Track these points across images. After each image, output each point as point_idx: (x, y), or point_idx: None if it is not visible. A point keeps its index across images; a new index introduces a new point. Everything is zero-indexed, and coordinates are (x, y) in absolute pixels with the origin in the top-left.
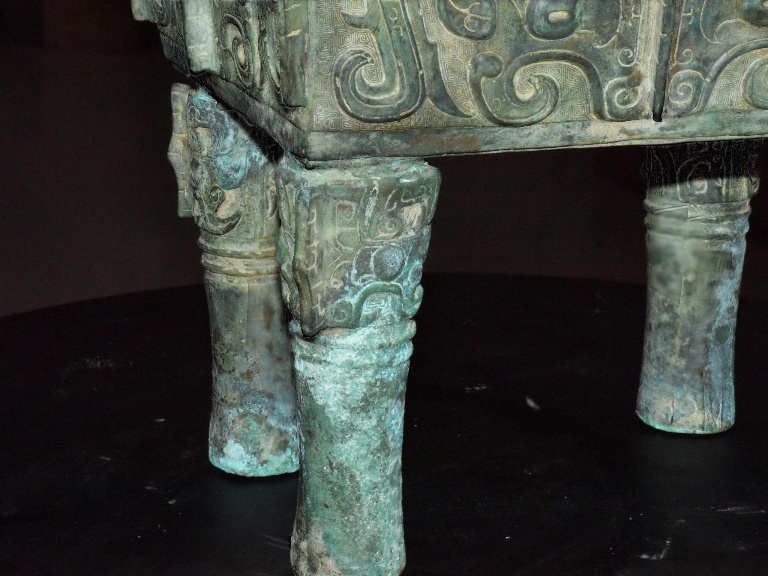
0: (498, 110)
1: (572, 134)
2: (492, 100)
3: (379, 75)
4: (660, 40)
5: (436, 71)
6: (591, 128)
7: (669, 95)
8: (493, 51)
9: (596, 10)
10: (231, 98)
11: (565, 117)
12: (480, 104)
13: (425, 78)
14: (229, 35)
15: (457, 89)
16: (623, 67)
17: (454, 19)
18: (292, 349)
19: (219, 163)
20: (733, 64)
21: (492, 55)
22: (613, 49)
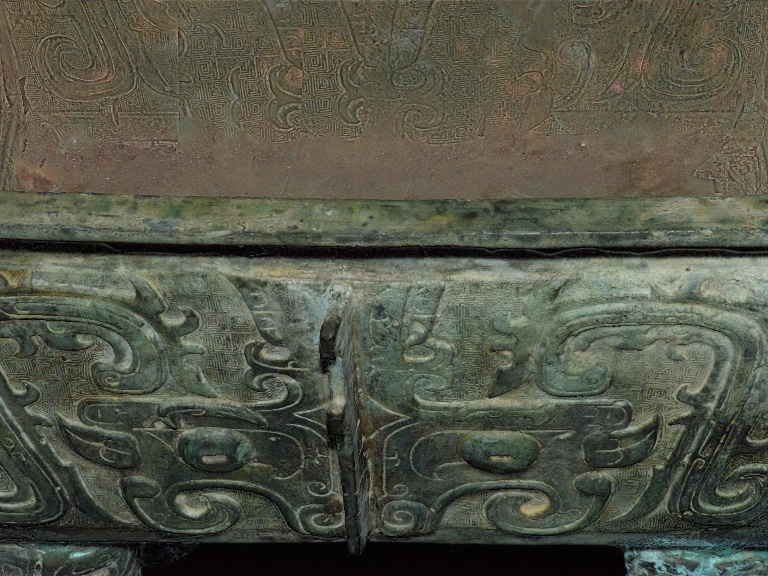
0: (163, 522)
1: (272, 535)
2: (153, 514)
3: (9, 486)
4: (343, 496)
5: (77, 488)
6: (294, 533)
7: (384, 519)
8: (144, 476)
9: (268, 449)
10: None
11: (255, 526)
12: (138, 517)
13: (66, 492)
14: None
15: (109, 501)
16: (316, 496)
17: (85, 451)
18: None
19: None
20: (467, 495)
21: (142, 481)
22: (300, 481)
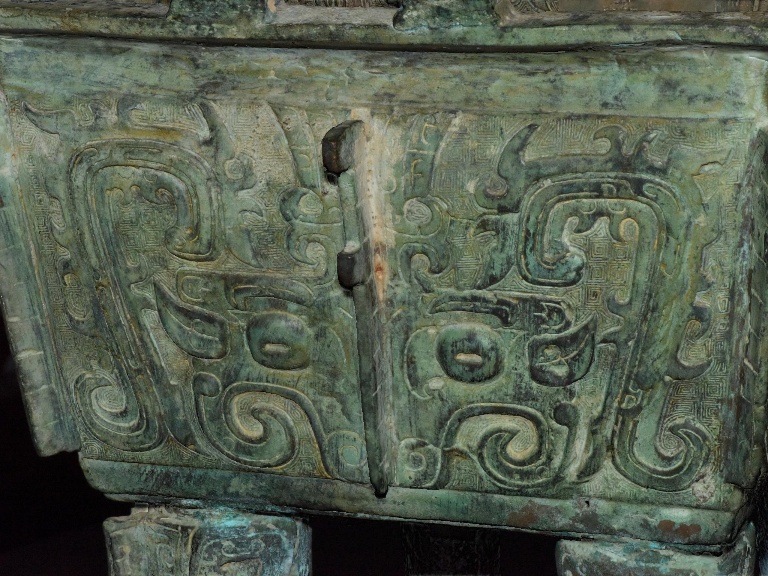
0: None
1: None
2: None
3: None
4: None
5: None
6: None
7: None
8: None
9: None
10: (425, 509)
11: None
12: None
13: None
14: (460, 430)
15: None
16: None
17: None
18: None
19: None
20: None
21: None
22: None
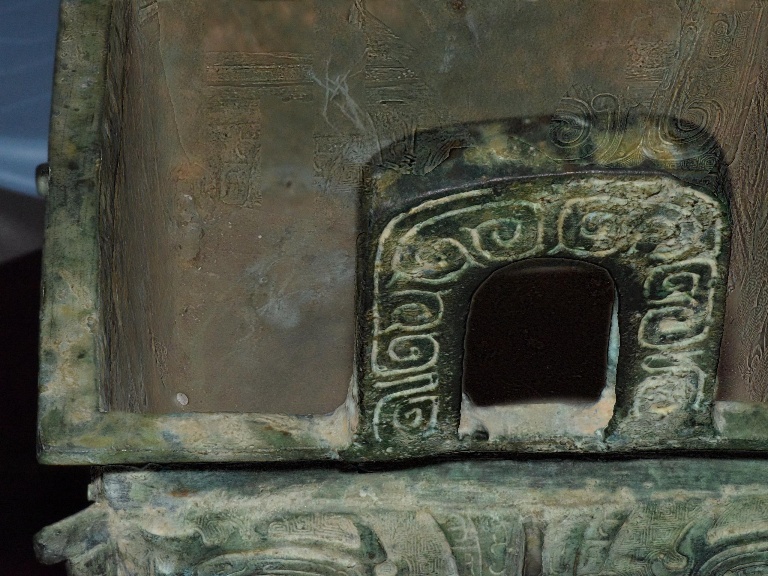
0: None
1: None
2: None
3: None
4: None
5: None
6: None
7: None
8: None
9: None
10: None
11: None
12: None
13: None
14: None
15: None
16: None
17: None
18: None
19: None
20: None
21: None
22: None
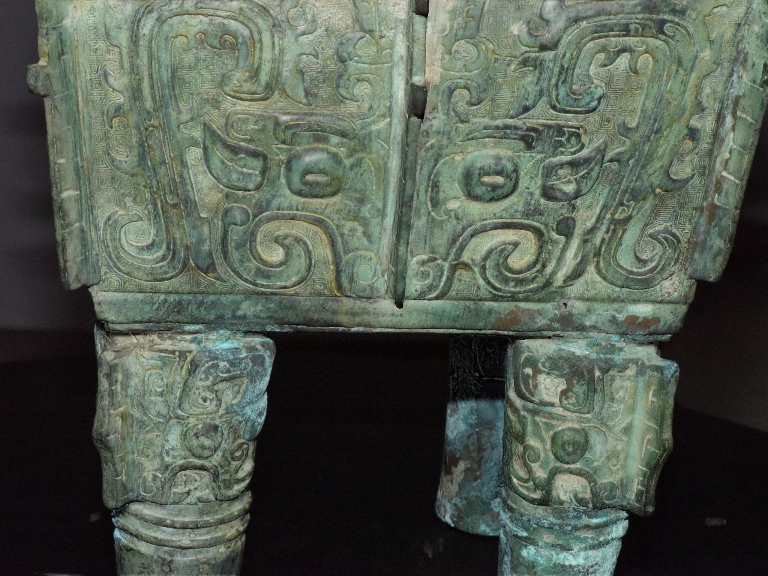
0: None
1: None
2: None
3: None
4: None
5: None
6: None
7: None
8: None
9: None
10: (421, 319)
11: None
12: None
13: None
14: (467, 245)
15: None
16: None
17: None
18: (568, 547)
19: (249, 414)
20: None
21: None
22: None
